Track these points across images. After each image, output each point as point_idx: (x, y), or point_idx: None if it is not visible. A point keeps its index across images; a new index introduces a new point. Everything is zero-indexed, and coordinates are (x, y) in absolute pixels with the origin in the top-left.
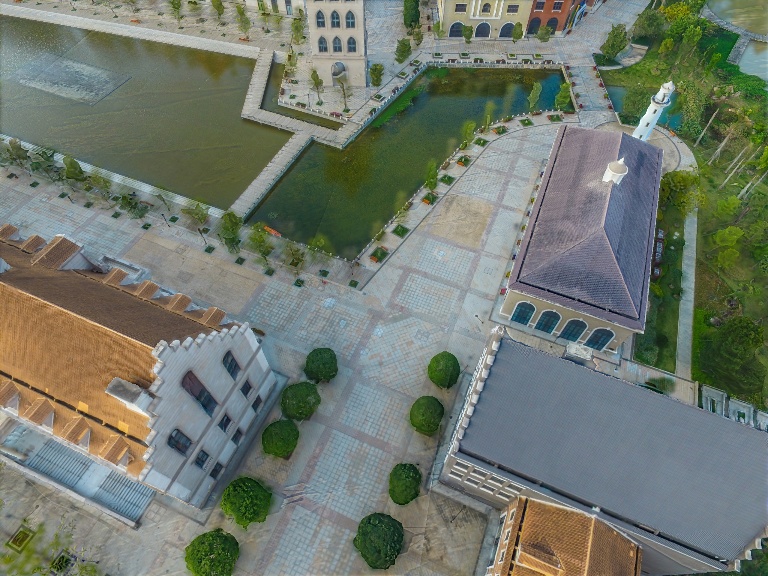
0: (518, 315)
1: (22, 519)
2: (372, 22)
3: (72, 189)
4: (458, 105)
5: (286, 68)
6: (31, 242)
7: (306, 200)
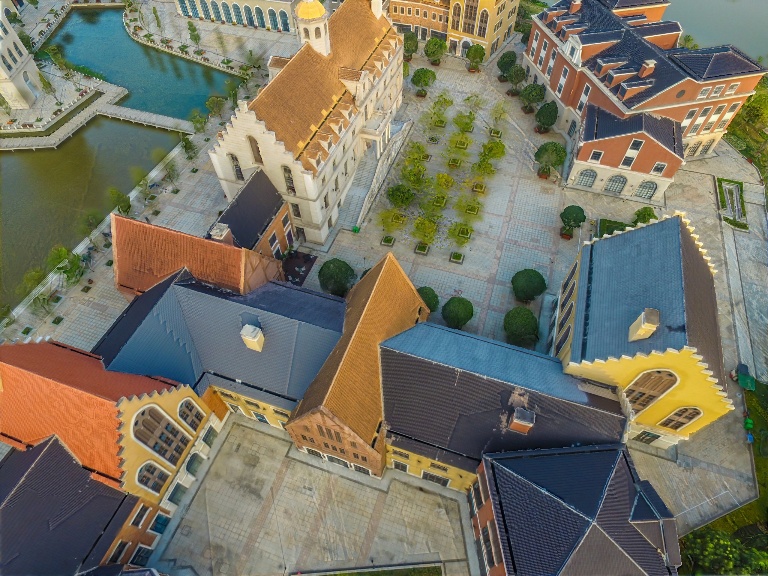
0: None
1: None
2: None
3: None
4: (94, 47)
5: None
6: None
7: (183, 104)
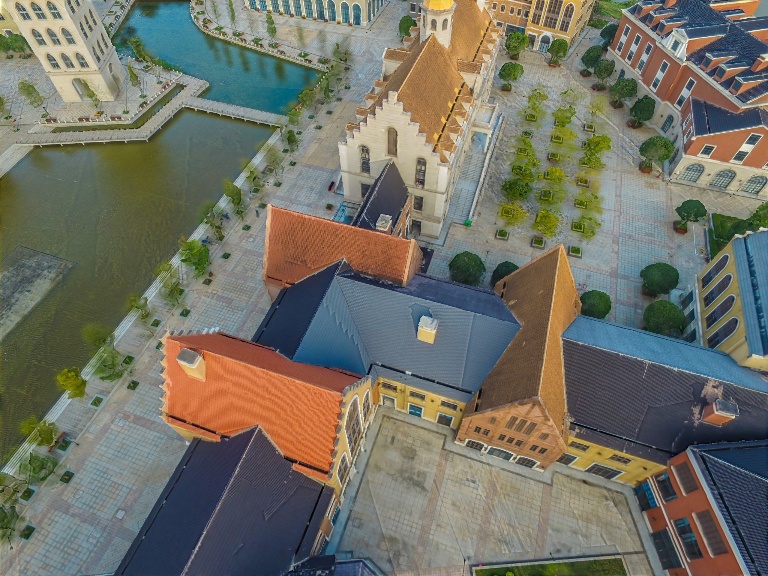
0: (368, 16)
1: (514, 155)
2: (3, 78)
3: (238, 224)
4: (165, 40)
5: (71, 121)
6: (381, 81)
7: (267, 97)
